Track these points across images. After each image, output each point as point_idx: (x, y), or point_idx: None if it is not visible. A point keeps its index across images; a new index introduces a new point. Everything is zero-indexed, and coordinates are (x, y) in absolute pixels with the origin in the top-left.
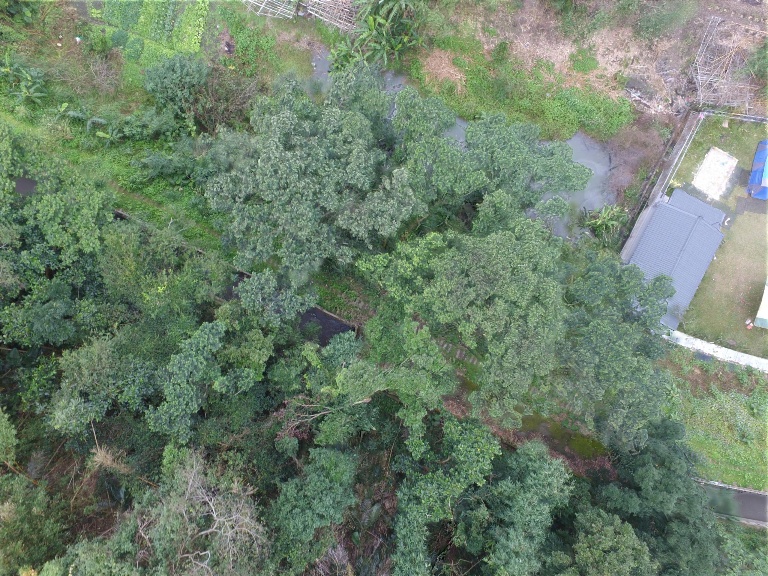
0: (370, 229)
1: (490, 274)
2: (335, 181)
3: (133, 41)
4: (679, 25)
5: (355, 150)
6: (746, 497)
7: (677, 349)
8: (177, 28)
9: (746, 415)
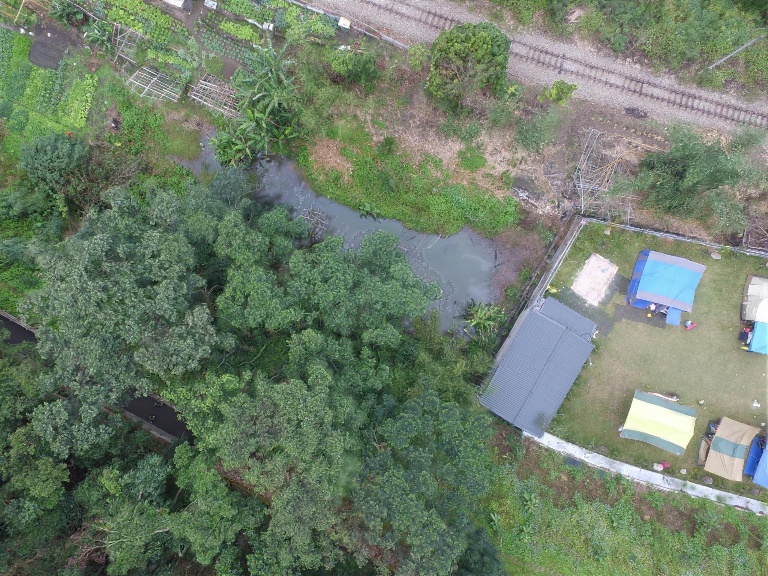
0: (165, 368)
1: (278, 424)
2: (141, 312)
3: (18, 113)
4: (564, 132)
5: (165, 281)
6: None
7: (547, 453)
8: (63, 102)
9: (605, 528)
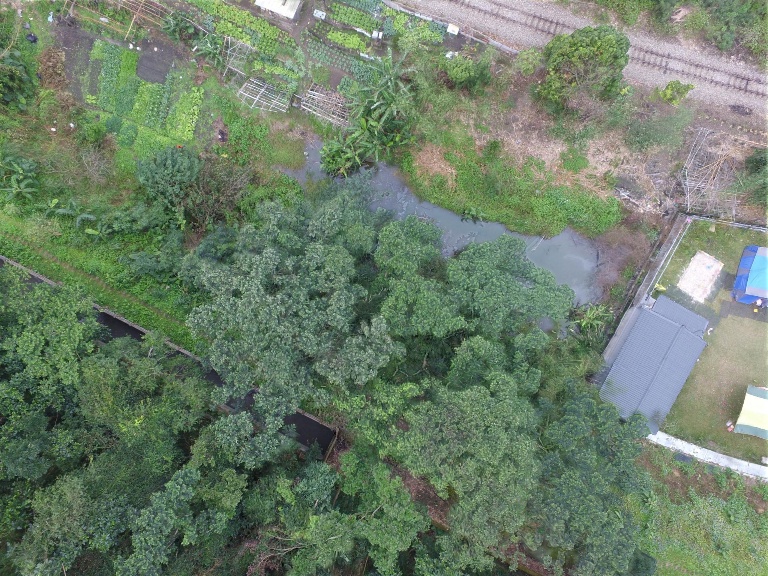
0: (347, 378)
1: (464, 430)
2: (315, 324)
3: (127, 127)
4: (669, 131)
5: (336, 292)
6: None
7: (657, 449)
8: (171, 116)
9: (723, 522)
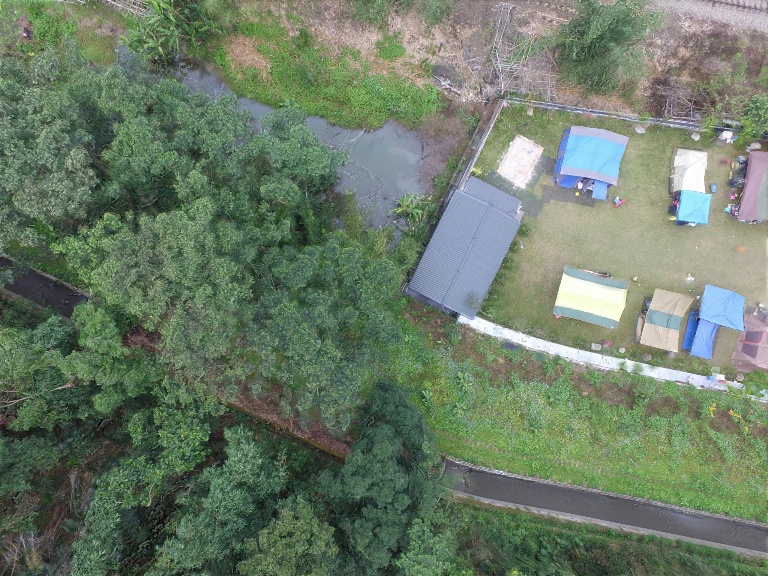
0: (45, 210)
1: (160, 255)
2: (21, 161)
3: None
4: (478, 12)
5: (44, 130)
6: (542, 487)
7: (483, 338)
8: None
9: (542, 404)
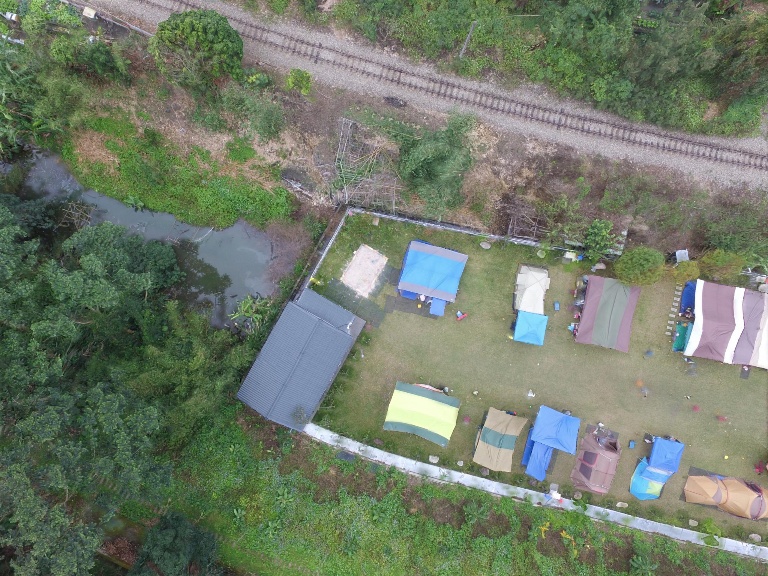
0: None
1: None
2: None
3: None
4: (325, 122)
5: None
6: None
7: (318, 447)
8: None
9: (365, 522)
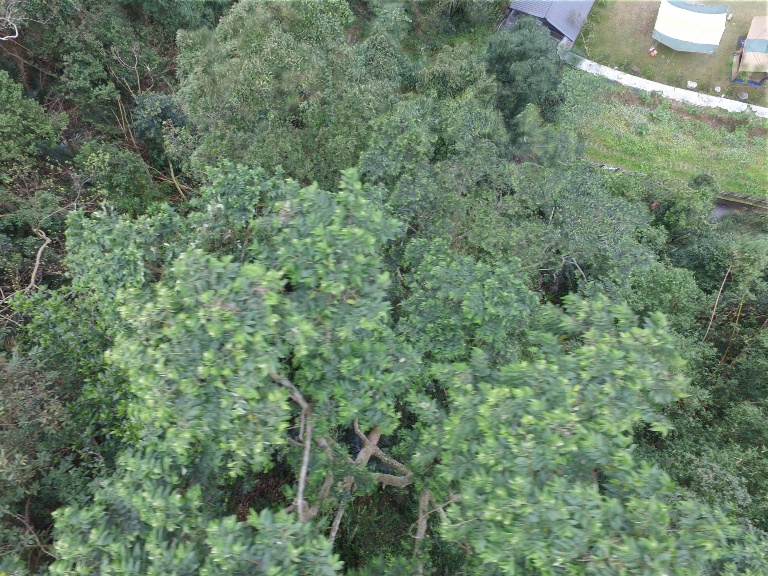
0: None
1: None
2: None
3: None
4: None
5: None
6: None
7: None
8: None
9: (645, 120)
